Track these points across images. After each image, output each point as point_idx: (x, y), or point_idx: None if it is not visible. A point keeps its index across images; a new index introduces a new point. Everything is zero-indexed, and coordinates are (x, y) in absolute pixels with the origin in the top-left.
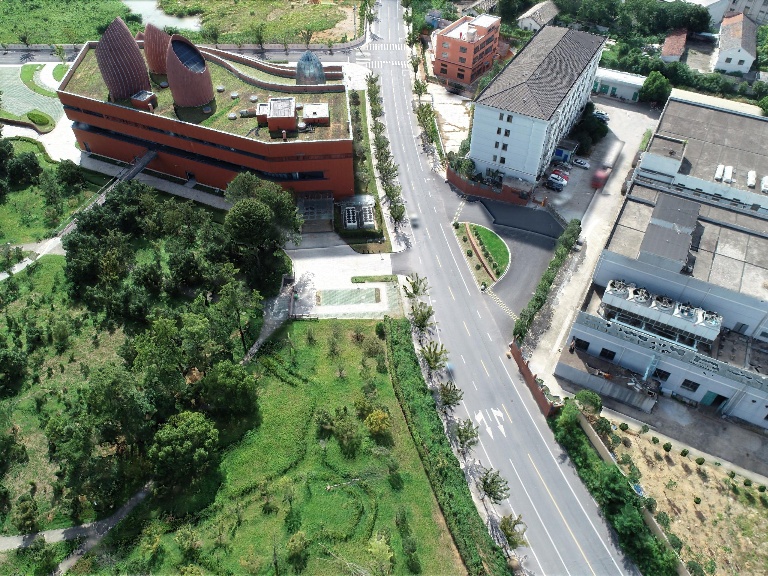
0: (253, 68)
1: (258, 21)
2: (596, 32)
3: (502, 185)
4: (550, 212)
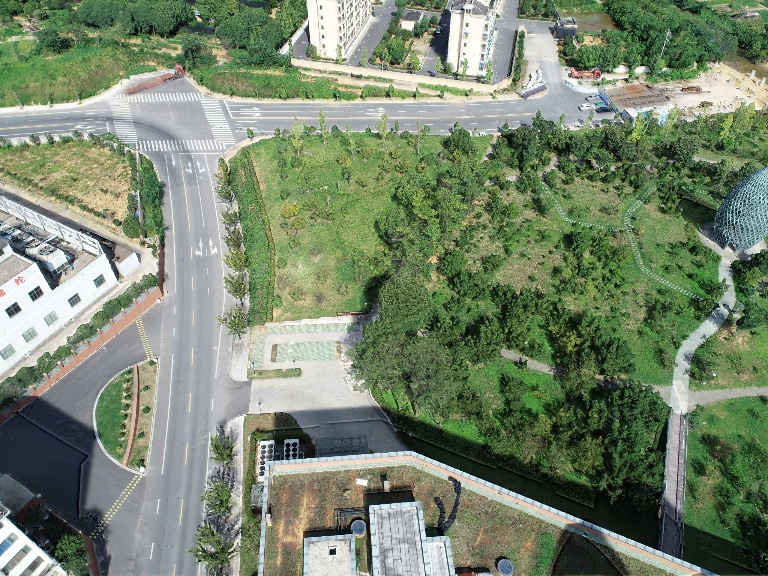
0: None
1: None
2: None
3: None
4: None
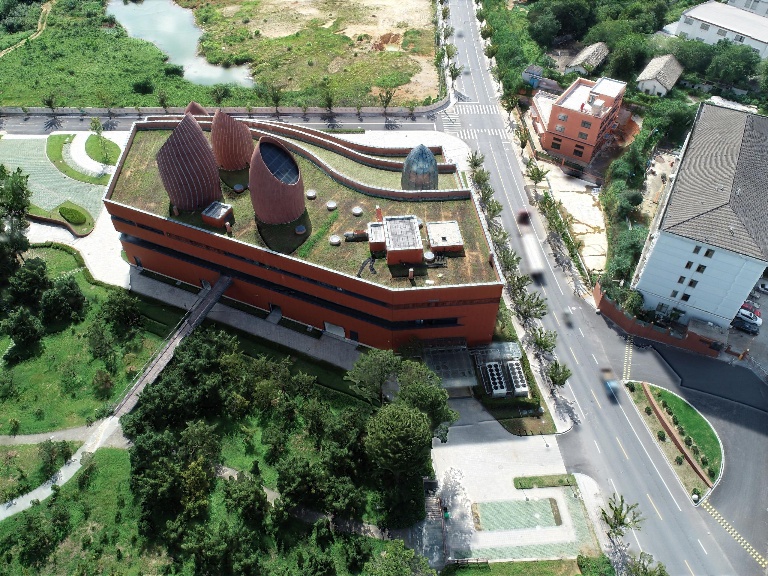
0: (339, 155)
1: (319, 74)
2: (732, 96)
3: (687, 331)
4: (754, 370)
